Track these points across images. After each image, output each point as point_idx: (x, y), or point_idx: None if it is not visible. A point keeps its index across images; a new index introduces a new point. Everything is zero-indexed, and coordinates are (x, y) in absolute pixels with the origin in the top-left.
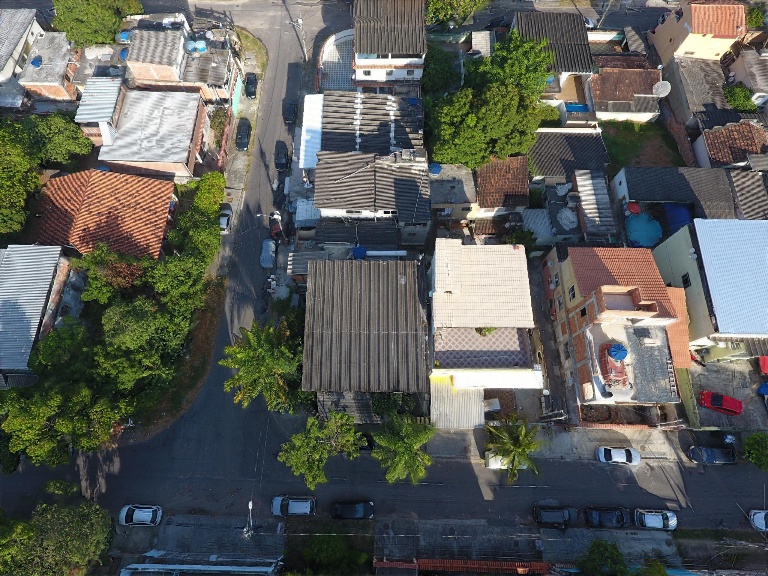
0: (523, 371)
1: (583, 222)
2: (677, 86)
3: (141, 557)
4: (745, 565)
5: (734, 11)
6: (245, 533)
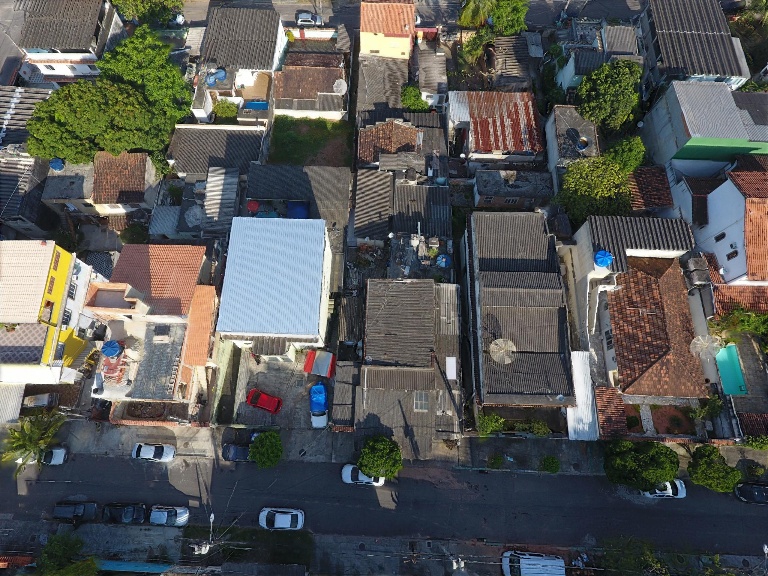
0: (38, 367)
1: None
2: None
3: None
4: (237, 562)
5: (403, 10)
6: None
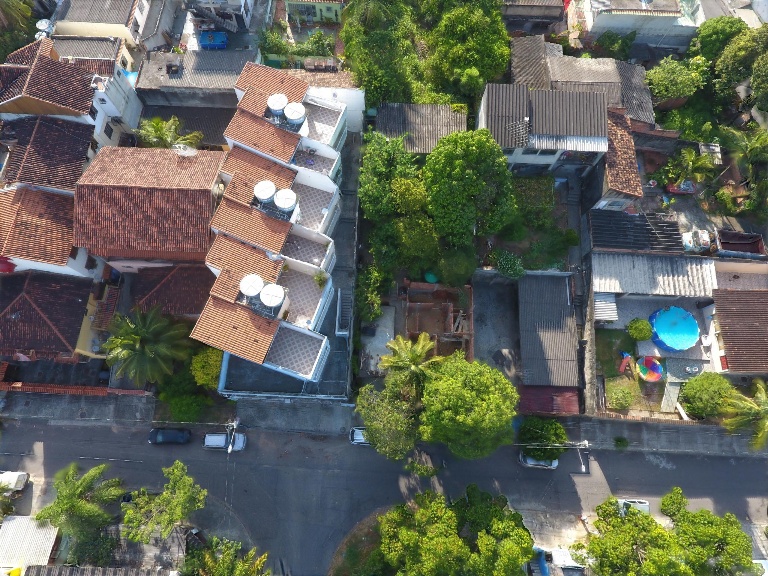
0: None
1: None
2: None
3: (354, 403)
4: None
5: None
6: (229, 426)
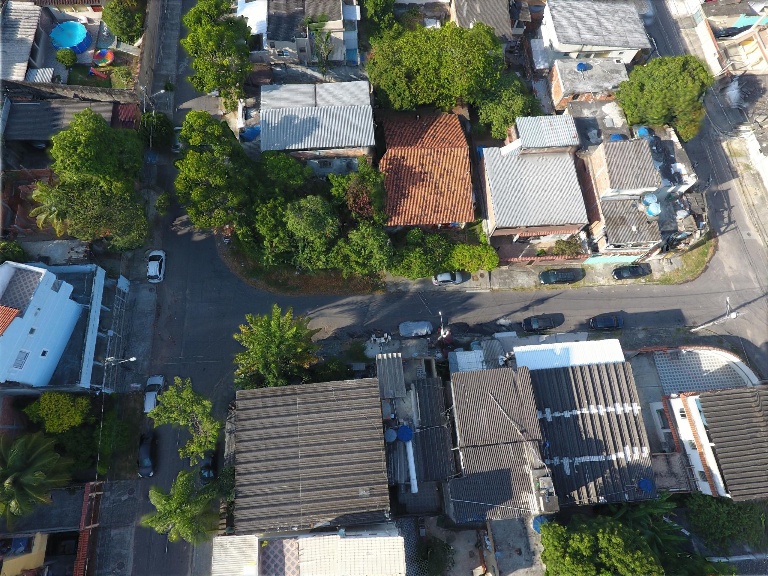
0: None
1: None
2: None
3: (119, 275)
4: None
5: None
6: (106, 359)
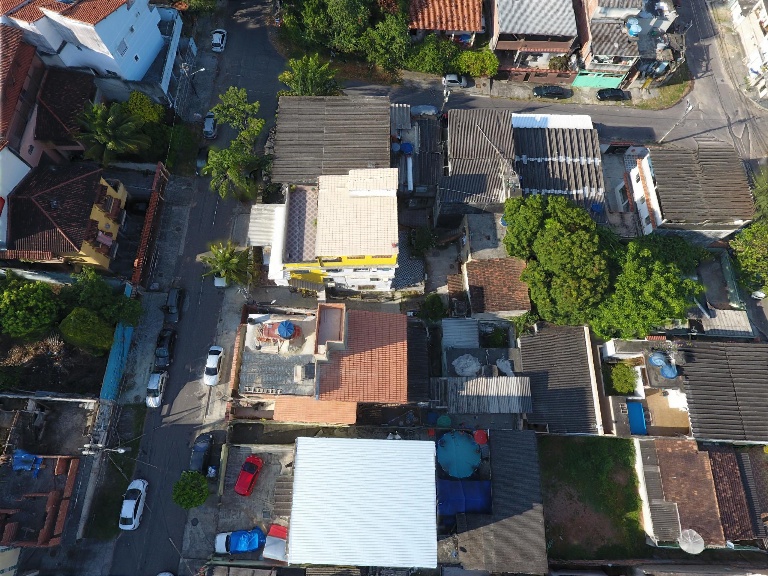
0: None
1: None
2: (703, 570)
3: (191, 36)
4: None
5: None
6: None
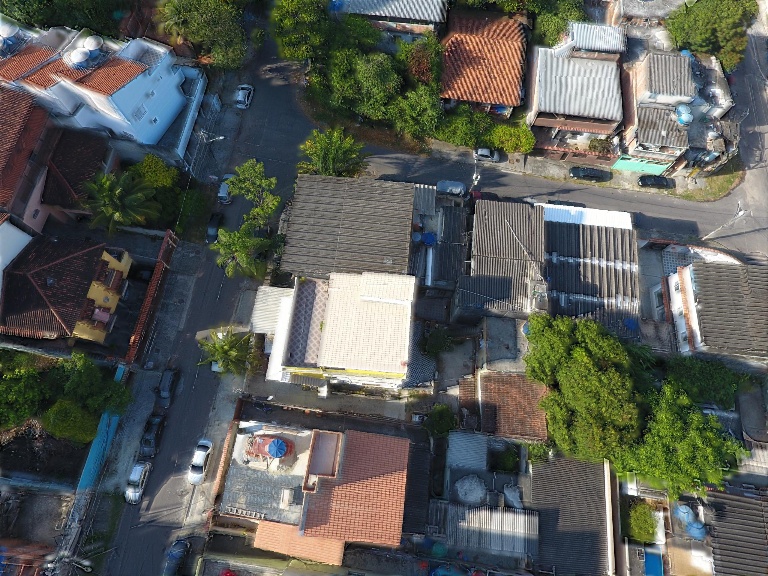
0: None
1: (463, 503)
2: None
3: (216, 93)
4: None
5: None
6: (202, 130)
